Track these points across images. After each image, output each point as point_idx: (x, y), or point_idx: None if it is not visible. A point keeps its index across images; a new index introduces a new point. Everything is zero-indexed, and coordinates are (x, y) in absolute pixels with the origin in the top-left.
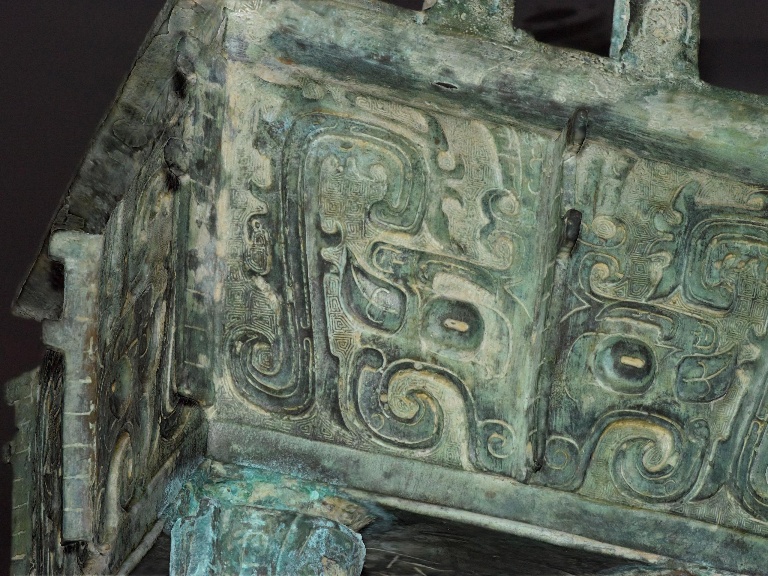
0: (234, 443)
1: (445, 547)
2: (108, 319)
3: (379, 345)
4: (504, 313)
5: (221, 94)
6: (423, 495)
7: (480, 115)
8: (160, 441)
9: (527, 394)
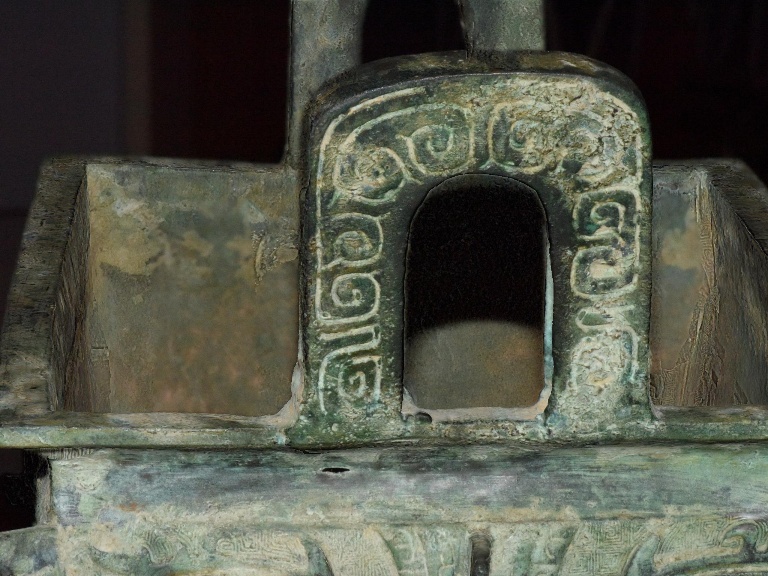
0: None
1: None
2: None
3: None
4: None
5: (54, 574)
6: None
7: (377, 511)
8: None
9: None
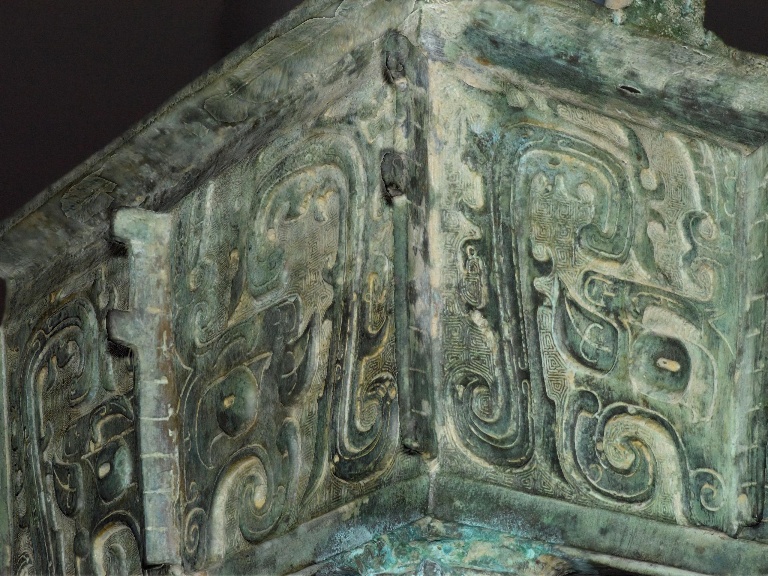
0: (456, 499)
1: None
2: (196, 316)
3: (593, 387)
4: (709, 350)
5: (425, 100)
6: (636, 552)
7: (669, 125)
8: (331, 480)
9: (733, 439)
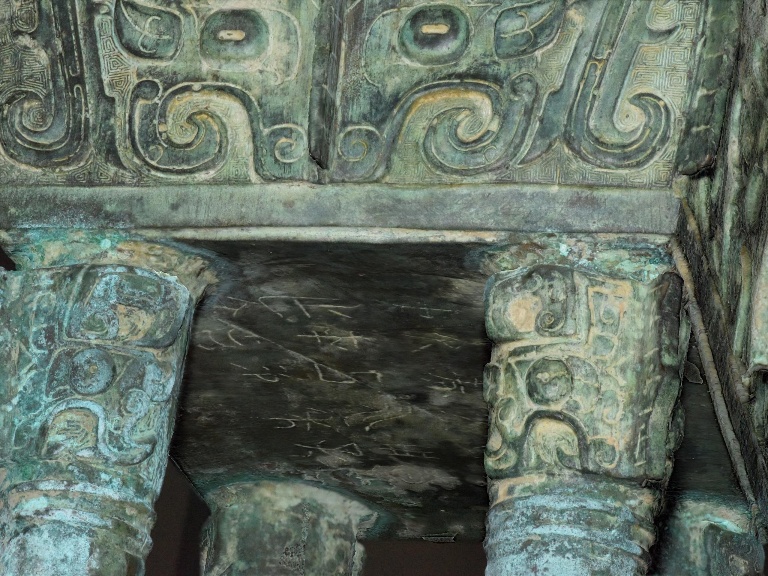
0: (11, 207)
1: (311, 277)
2: None
3: (155, 75)
4: (289, 11)
5: None
6: (216, 220)
7: None
8: None
9: None
